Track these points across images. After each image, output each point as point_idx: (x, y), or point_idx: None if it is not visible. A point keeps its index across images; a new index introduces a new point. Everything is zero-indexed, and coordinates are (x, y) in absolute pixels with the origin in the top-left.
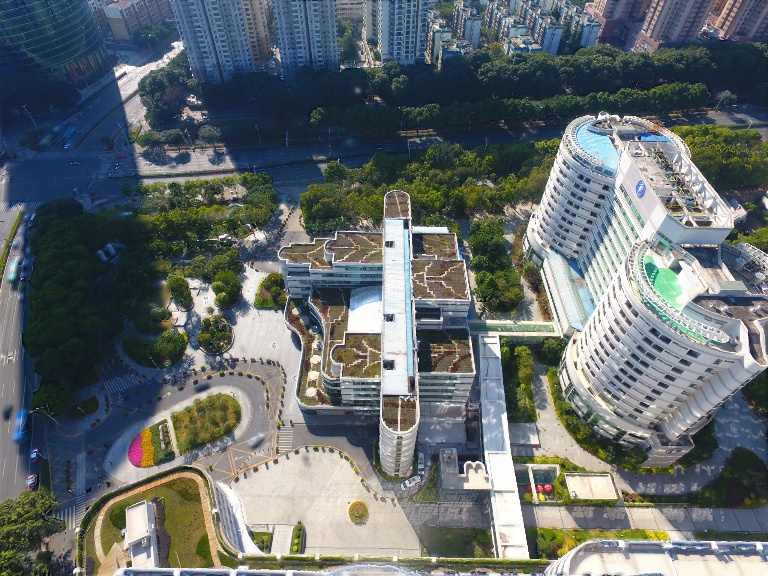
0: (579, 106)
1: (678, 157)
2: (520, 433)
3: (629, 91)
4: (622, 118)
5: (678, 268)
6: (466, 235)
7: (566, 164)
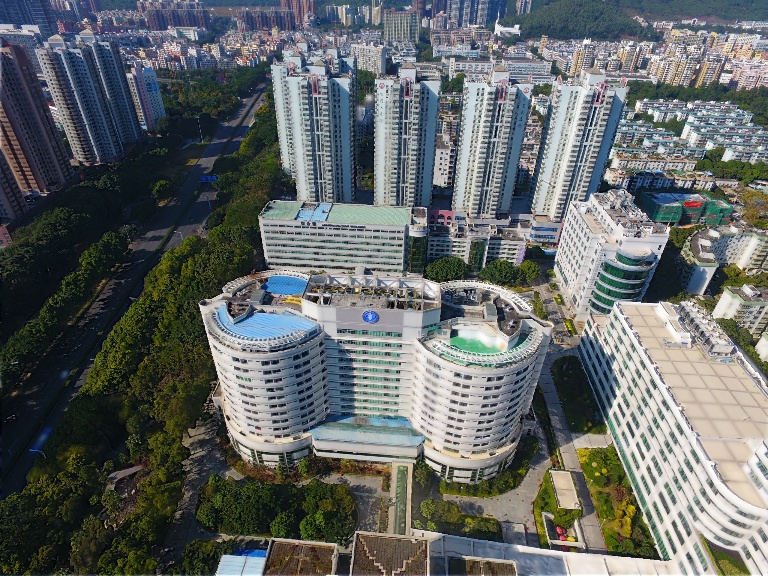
0: (51, 326)
1: (330, 279)
2: (515, 541)
3: (71, 278)
4: (85, 303)
5: (451, 333)
6: (205, 536)
7: (270, 362)
